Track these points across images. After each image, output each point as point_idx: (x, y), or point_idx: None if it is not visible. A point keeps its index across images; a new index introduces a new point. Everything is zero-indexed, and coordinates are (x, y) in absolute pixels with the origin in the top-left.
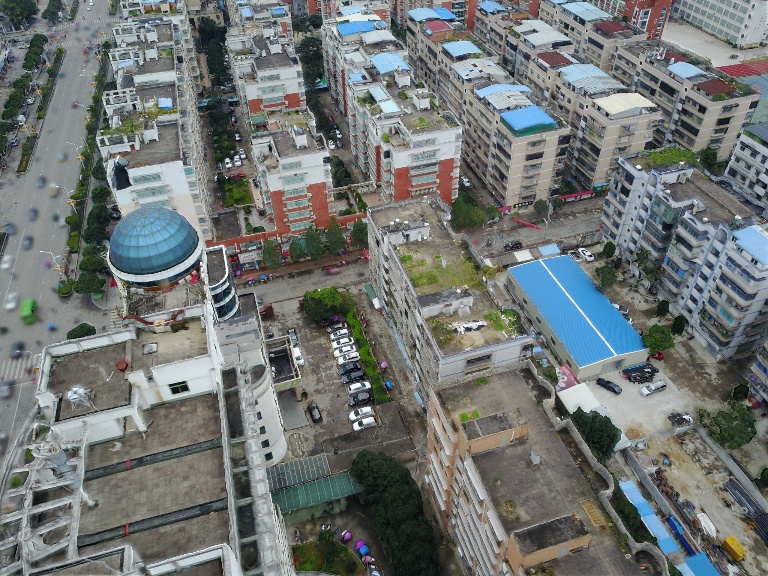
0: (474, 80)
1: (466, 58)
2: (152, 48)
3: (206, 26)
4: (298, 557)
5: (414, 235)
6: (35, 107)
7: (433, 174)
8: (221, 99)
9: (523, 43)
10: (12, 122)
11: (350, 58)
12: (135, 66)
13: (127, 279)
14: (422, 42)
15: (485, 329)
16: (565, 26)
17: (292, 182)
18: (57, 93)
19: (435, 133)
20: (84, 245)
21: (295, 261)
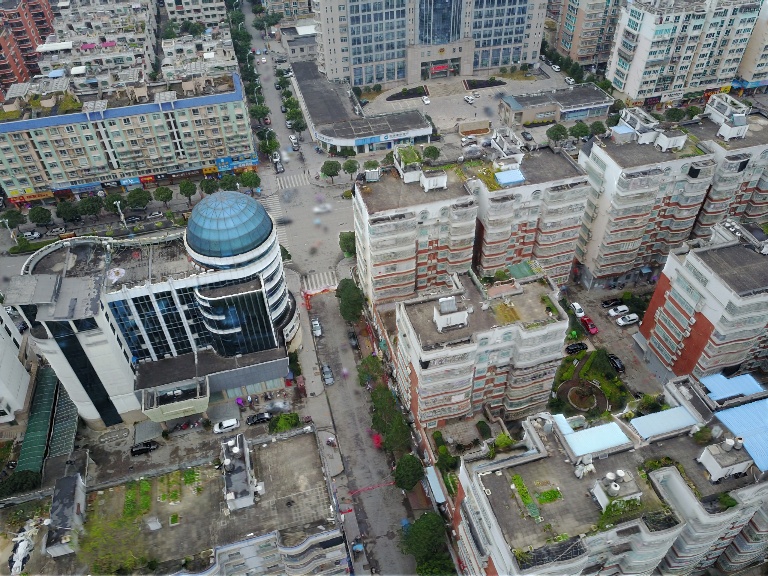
0: None
1: None
2: (668, 135)
3: None
4: (1, 446)
5: None
6: None
7: None
8: None
9: None
10: None
11: None
12: (630, 139)
13: None
14: None
15: (5, 570)
16: None
17: None
18: None
19: None
20: None
21: None
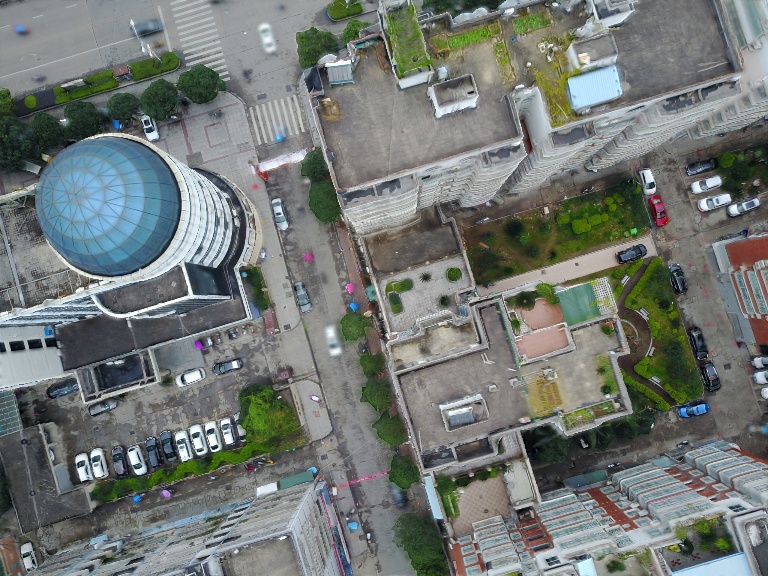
0: None
1: None
2: None
3: None
4: None
5: None
6: None
7: None
8: None
9: None
10: None
11: None
12: None
13: None
14: None
15: None
16: None
17: None
18: None
19: None
20: None
21: None
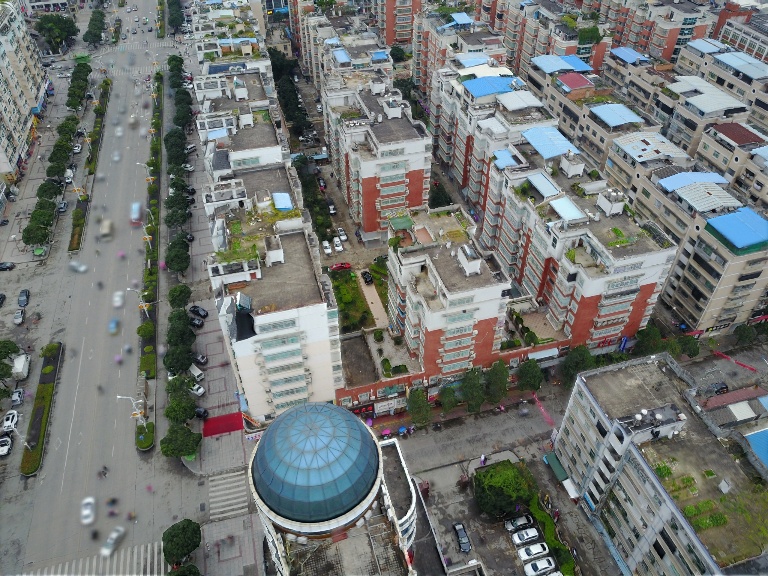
0: (650, 163)
1: (621, 126)
2: (248, 113)
3: (275, 59)
4: None
5: (664, 431)
6: (83, 157)
7: (628, 302)
8: (307, 158)
9: (685, 107)
10: (58, 179)
11: (487, 127)
12: (227, 136)
13: (285, 526)
14: (553, 98)
15: None
16: (718, 81)
17: (458, 320)
18: (107, 139)
19: (644, 256)
20: (162, 366)
21: (440, 405)
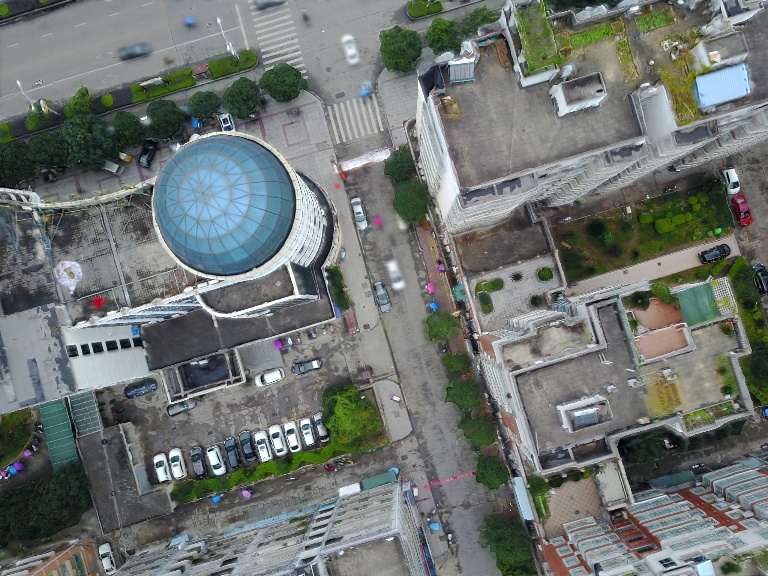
0: None
1: None
2: None
3: None
4: None
5: None
6: None
7: None
8: None
9: None
10: None
11: None
12: None
13: None
14: None
15: None
16: None
17: None
18: None
19: None
20: None
21: None
